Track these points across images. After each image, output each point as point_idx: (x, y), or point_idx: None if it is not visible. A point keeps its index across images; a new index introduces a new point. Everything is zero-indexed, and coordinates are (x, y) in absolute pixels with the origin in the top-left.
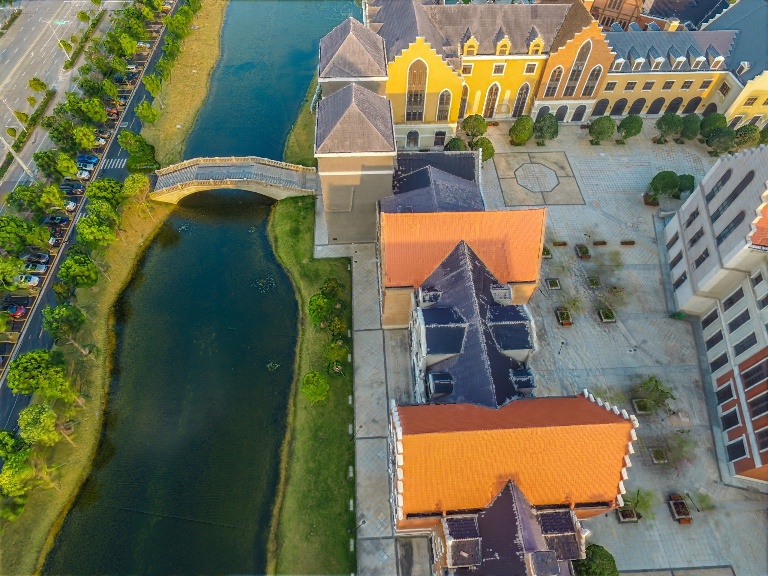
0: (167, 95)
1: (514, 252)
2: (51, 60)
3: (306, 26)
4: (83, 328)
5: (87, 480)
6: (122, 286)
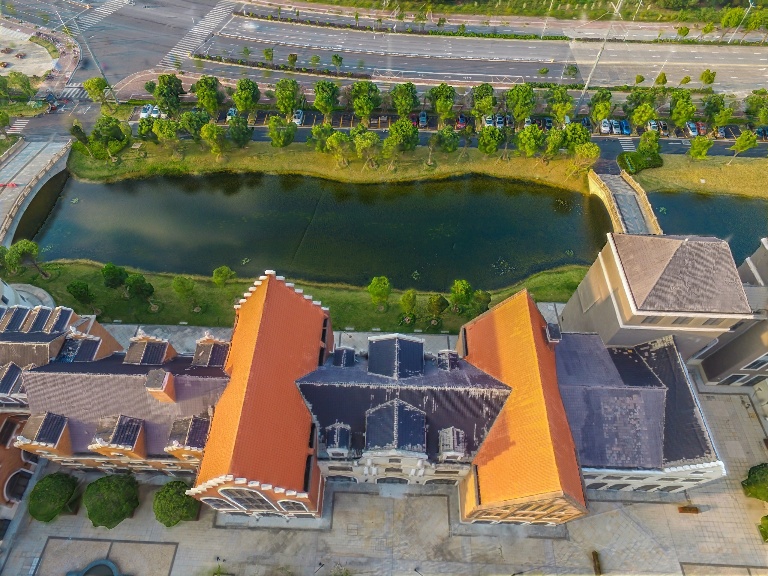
0: (750, 165)
1: (507, 462)
2: (762, 81)
3: None
4: (450, 158)
5: (340, 182)
6: (492, 174)
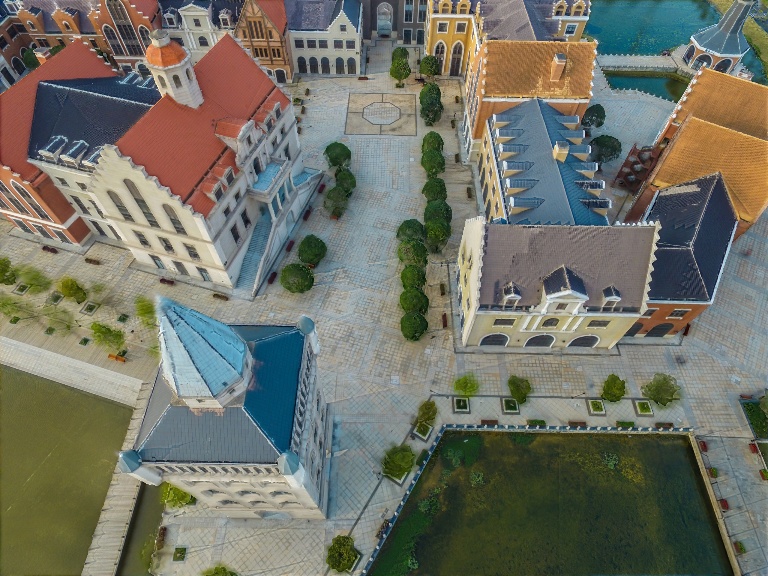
0: None
1: None
2: None
3: (615, 21)
4: None
5: None
6: None
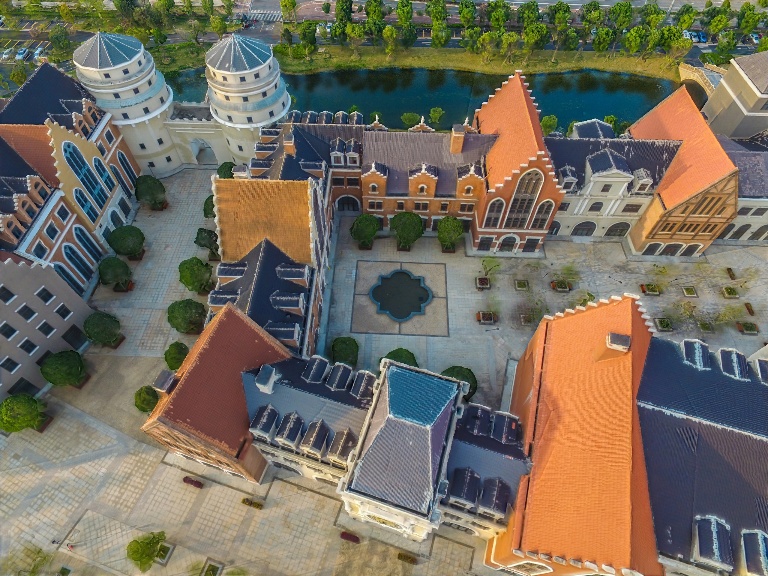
0: None
1: (687, 178)
2: None
3: None
4: (568, 58)
5: (485, 74)
6: (602, 69)
